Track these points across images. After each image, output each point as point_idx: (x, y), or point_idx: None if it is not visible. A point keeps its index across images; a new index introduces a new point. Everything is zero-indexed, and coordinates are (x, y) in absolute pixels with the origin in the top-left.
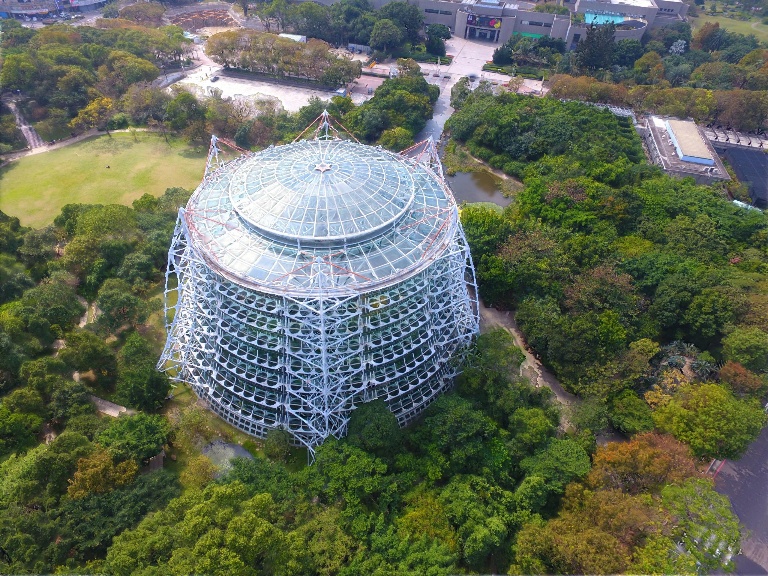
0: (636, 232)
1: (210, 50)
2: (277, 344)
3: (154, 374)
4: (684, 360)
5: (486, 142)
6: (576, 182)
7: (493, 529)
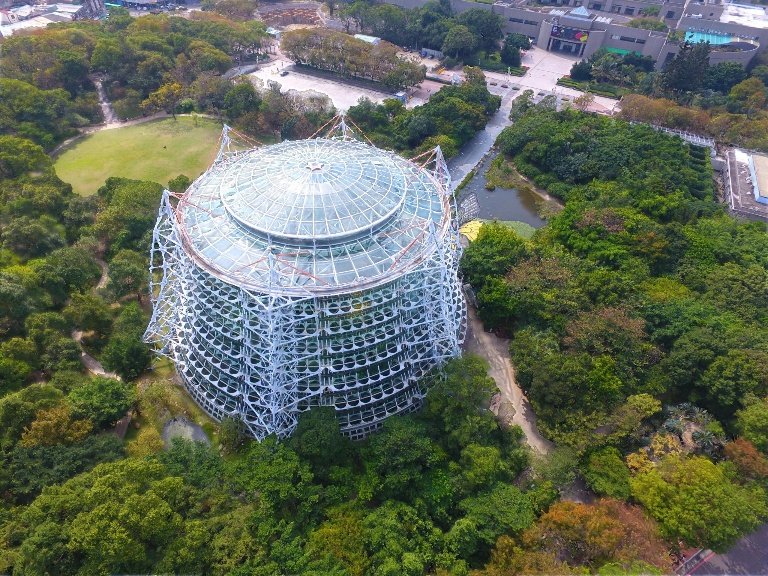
0: (674, 275)
1: (284, 46)
2: (239, 334)
3: (136, 344)
4: (685, 426)
5: (534, 159)
6: (615, 212)
7: (405, 565)
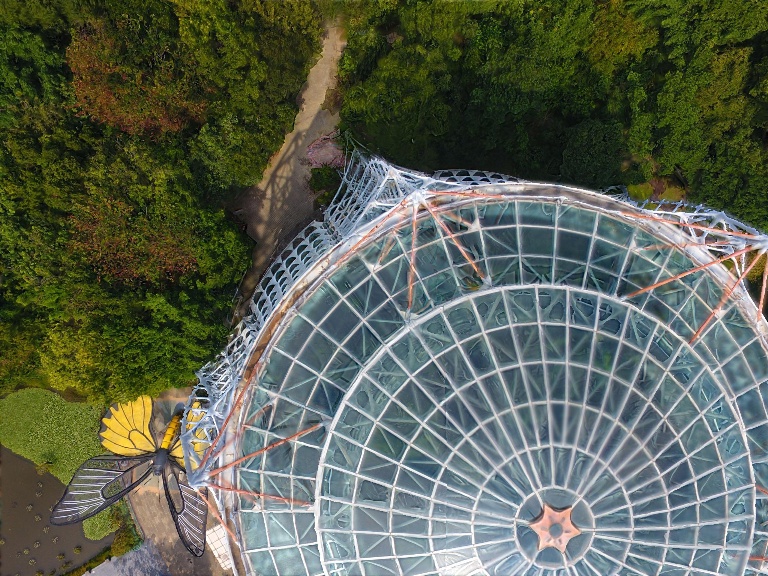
0: None
1: None
2: None
3: None
4: None
5: None
6: None
7: None
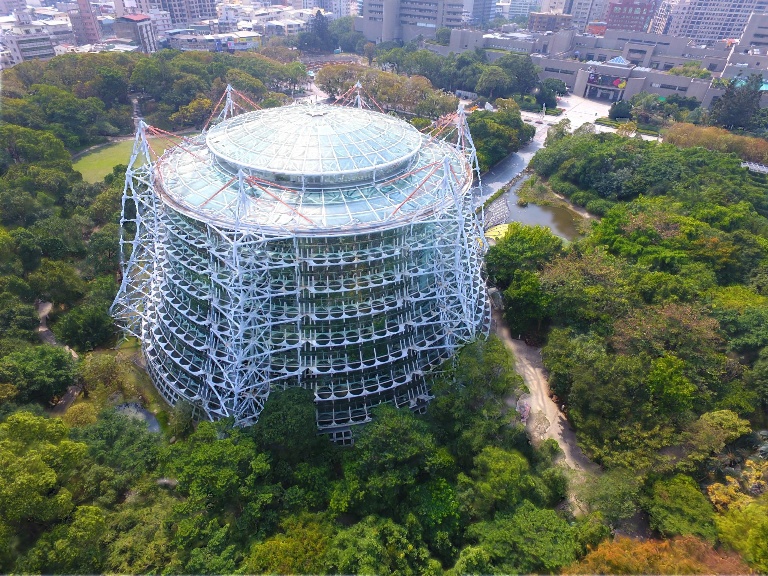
0: (747, 286)
1: (319, 80)
2: (207, 294)
3: (97, 313)
4: None
5: (571, 176)
6: None
7: None
